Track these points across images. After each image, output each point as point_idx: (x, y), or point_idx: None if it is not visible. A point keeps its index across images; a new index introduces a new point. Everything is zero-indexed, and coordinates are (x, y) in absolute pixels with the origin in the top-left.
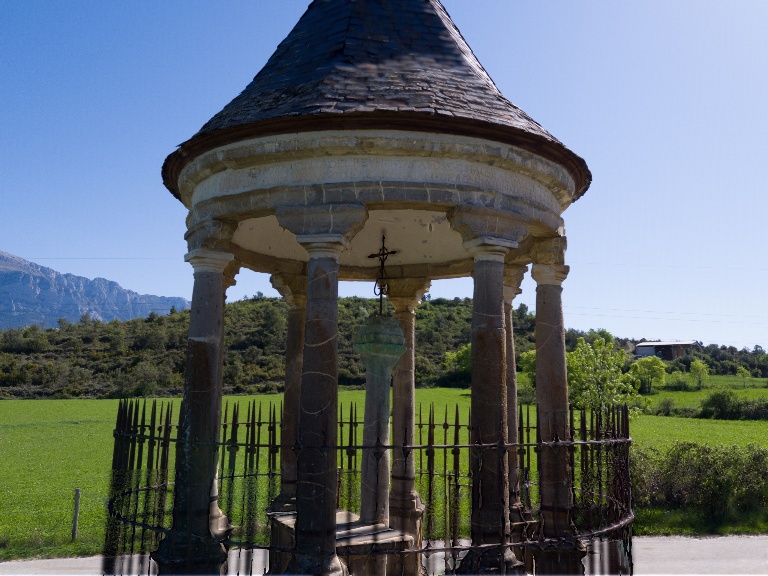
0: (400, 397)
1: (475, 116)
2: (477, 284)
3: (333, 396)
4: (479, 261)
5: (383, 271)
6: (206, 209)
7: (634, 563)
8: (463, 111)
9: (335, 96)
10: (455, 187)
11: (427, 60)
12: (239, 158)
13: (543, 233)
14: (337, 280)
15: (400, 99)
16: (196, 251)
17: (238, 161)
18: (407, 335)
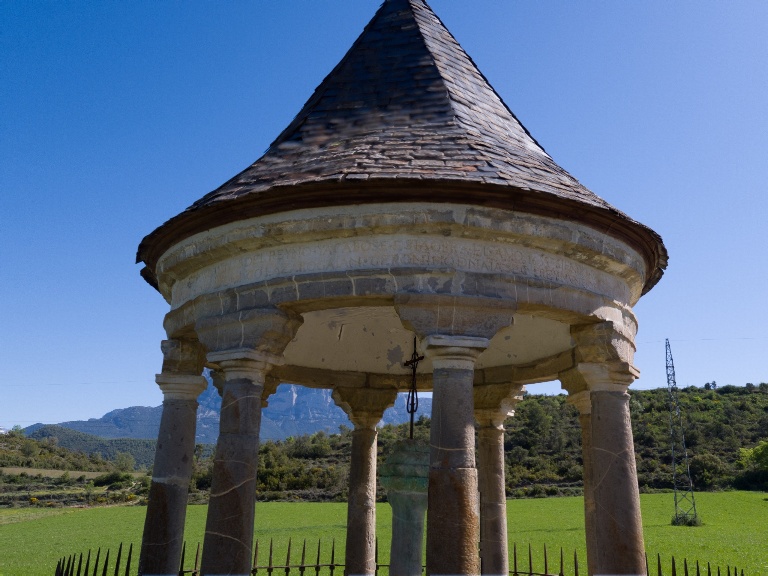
0: (485, 540)
1: (402, 174)
2: (433, 403)
3: (236, 566)
4: (434, 370)
5: (414, 382)
6: (166, 328)
7: None
8: (390, 171)
9: (247, 180)
10: (388, 272)
11: (398, 118)
12: (172, 267)
13: (574, 319)
14: (255, 407)
15: (315, 170)
16: (157, 376)
17: (175, 271)
18: (492, 457)
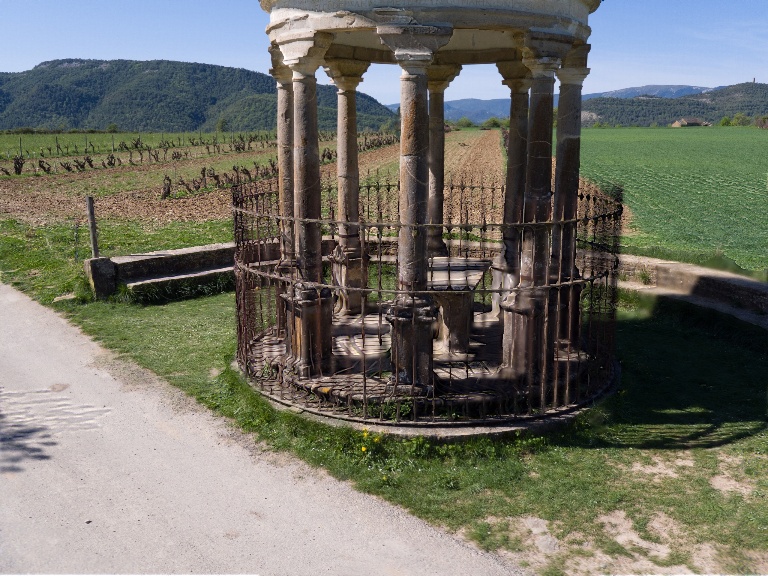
0: None
1: None
2: None
3: None
4: None
5: None
6: None
7: (13, 360)
8: None
9: None
10: None
11: None
12: None
13: None
14: None
15: None
16: None
17: None
18: None
